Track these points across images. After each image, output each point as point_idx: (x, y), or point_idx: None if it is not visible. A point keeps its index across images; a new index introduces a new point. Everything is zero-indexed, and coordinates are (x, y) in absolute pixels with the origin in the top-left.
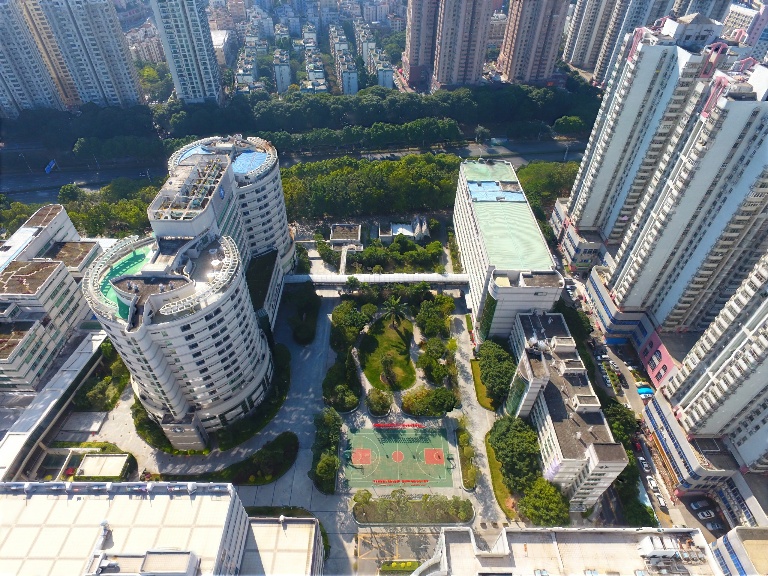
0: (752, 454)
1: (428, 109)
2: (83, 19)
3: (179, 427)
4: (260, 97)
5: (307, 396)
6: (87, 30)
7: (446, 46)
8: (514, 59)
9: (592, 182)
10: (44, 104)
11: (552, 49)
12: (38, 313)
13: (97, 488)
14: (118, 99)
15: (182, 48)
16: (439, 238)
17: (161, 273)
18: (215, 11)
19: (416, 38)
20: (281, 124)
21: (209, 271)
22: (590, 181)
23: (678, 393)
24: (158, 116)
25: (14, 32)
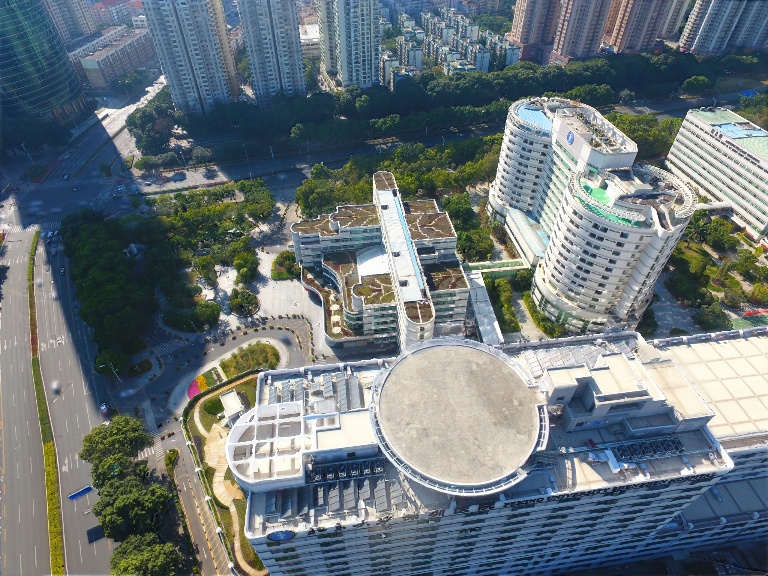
0: None
1: (573, 79)
2: (278, 13)
3: (629, 324)
4: (430, 78)
5: (665, 303)
6: (280, 23)
7: (574, 22)
8: (627, 31)
9: None
10: (221, 99)
11: (662, 19)
12: (448, 255)
13: (733, 334)
14: (292, 89)
15: (362, 36)
16: None
17: (649, 191)
18: (308, 6)
19: (528, 18)
20: (452, 101)
21: None
22: None
23: None
24: (346, 101)
25: (209, 29)
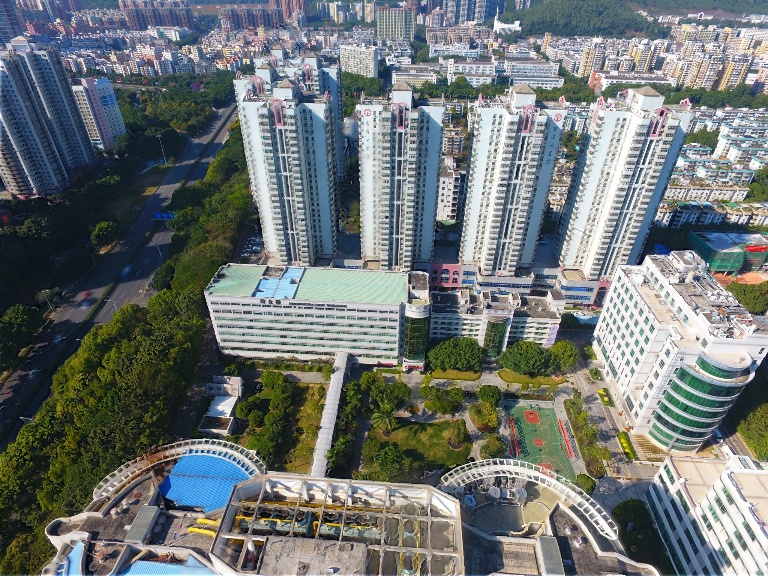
0: (529, 257)
1: None
2: None
3: None
4: None
5: None
6: None
7: None
8: None
9: (306, 225)
10: None
11: None
12: None
13: None
14: None
15: None
16: (246, 376)
17: None
18: None
19: None
20: None
21: (498, 511)
22: (303, 225)
23: (493, 266)
24: None
25: None
